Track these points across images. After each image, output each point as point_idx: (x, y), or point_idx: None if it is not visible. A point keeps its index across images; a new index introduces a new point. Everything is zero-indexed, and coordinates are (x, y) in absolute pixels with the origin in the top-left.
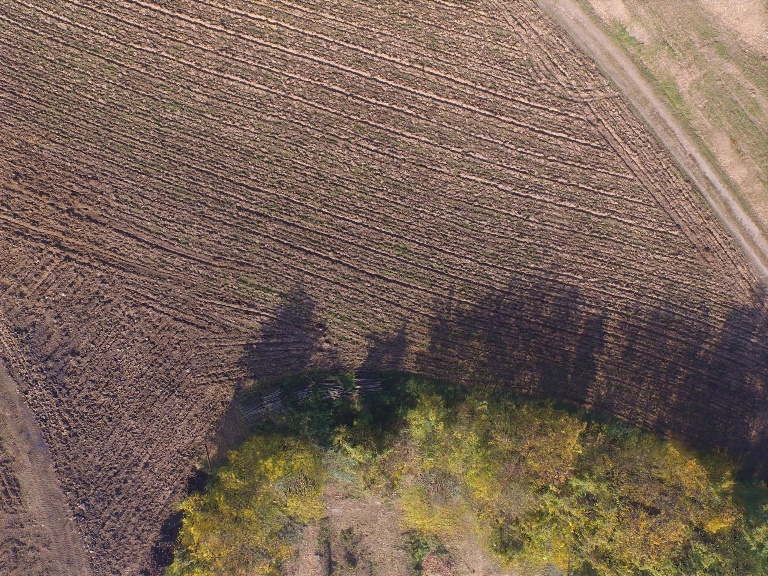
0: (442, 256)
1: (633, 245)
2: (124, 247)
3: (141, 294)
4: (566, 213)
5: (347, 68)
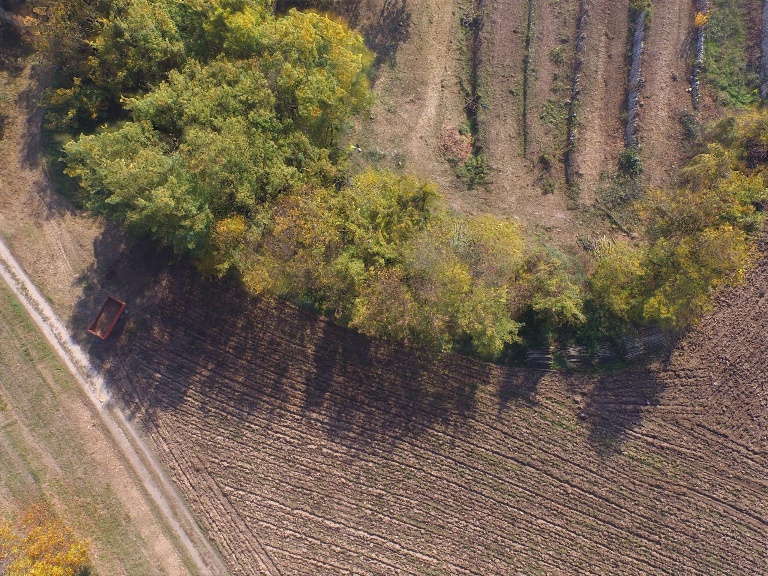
0: (459, 480)
1: (270, 479)
2: None
3: (759, 464)
4: (335, 515)
5: None
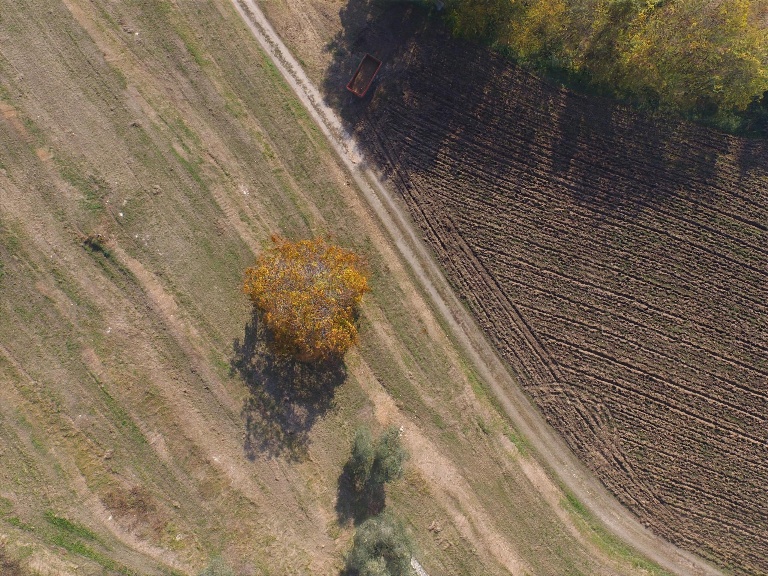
0: (703, 244)
1: (519, 240)
2: None
3: None
4: (583, 276)
5: None
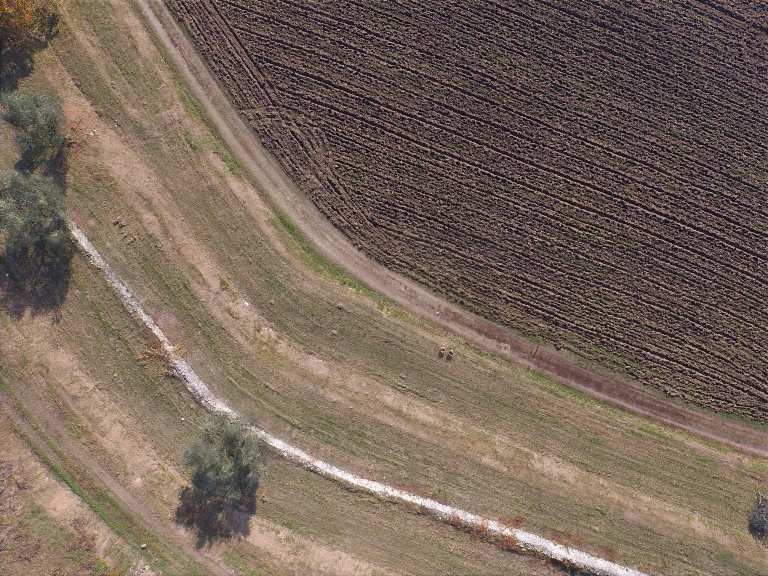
0: None
1: None
2: (736, 3)
3: None
4: (303, 1)
5: (506, 156)
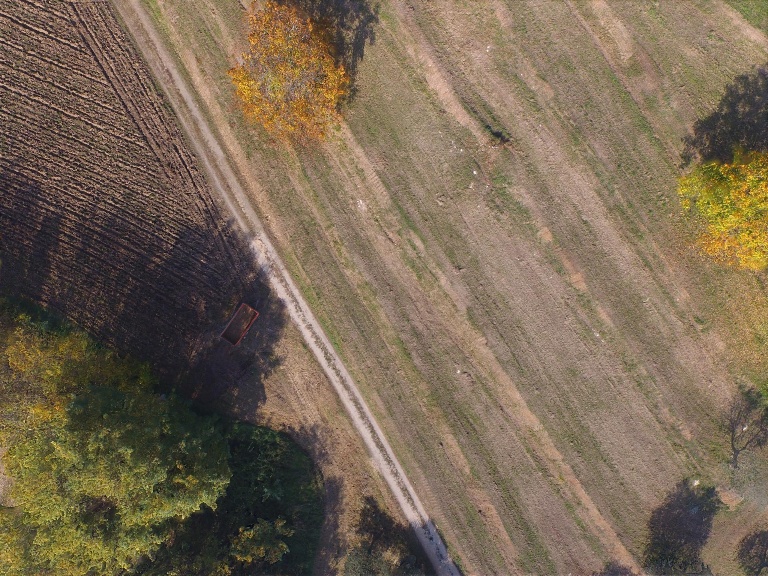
0: None
1: (99, 150)
2: None
3: None
4: (38, 108)
5: None
